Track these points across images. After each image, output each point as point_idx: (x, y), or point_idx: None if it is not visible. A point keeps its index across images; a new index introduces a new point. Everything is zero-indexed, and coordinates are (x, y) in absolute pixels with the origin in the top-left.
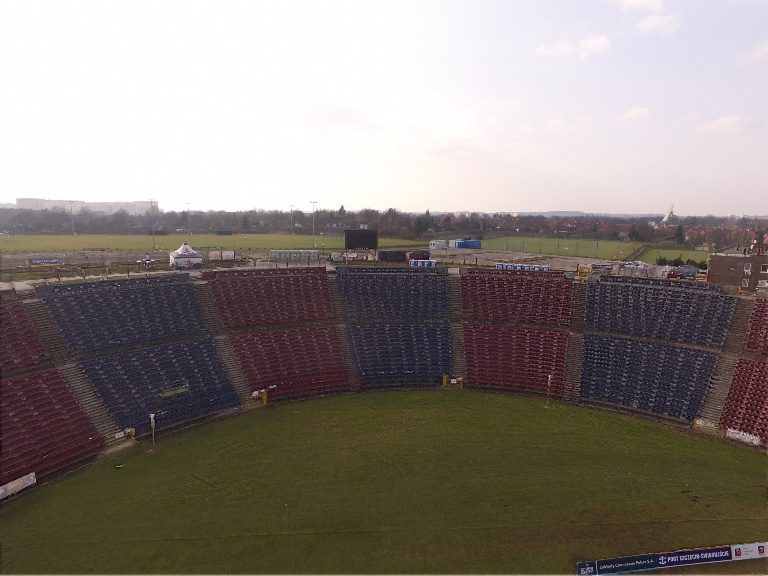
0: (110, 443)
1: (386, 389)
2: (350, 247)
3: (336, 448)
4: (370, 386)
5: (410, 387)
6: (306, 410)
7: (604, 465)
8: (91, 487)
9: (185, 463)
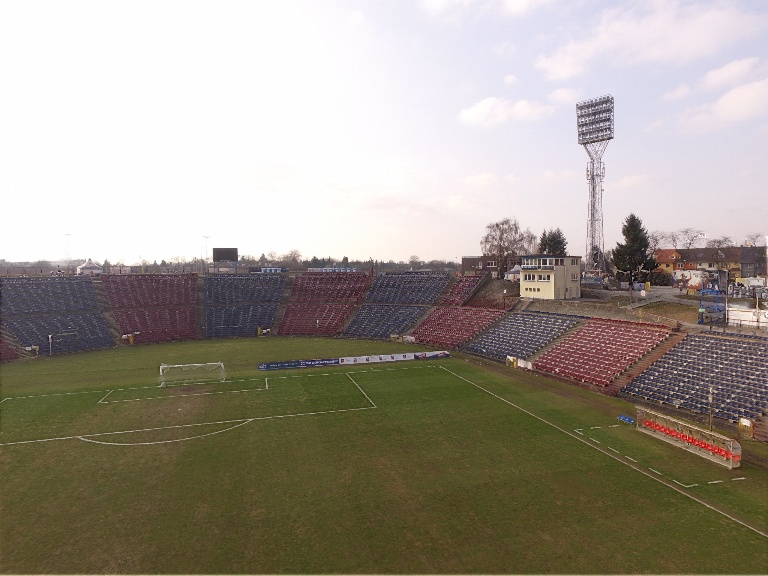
0: (22, 357)
1: (219, 338)
2: (217, 260)
3: None
4: (210, 338)
5: None
6: (159, 346)
7: None
8: (9, 367)
9: (69, 360)
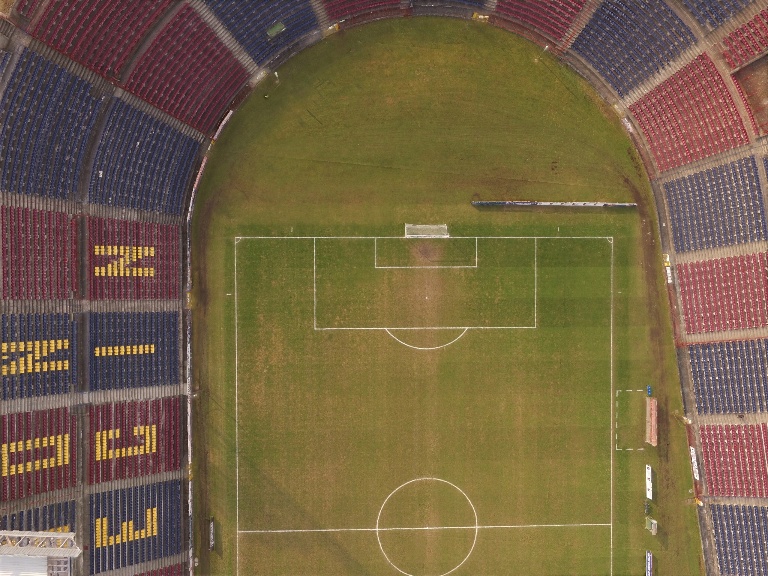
0: (251, 72)
1: (428, 14)
2: None
3: (385, 95)
4: (416, 5)
5: (448, 8)
6: (366, 40)
7: (529, 135)
8: (260, 115)
9: (301, 99)
